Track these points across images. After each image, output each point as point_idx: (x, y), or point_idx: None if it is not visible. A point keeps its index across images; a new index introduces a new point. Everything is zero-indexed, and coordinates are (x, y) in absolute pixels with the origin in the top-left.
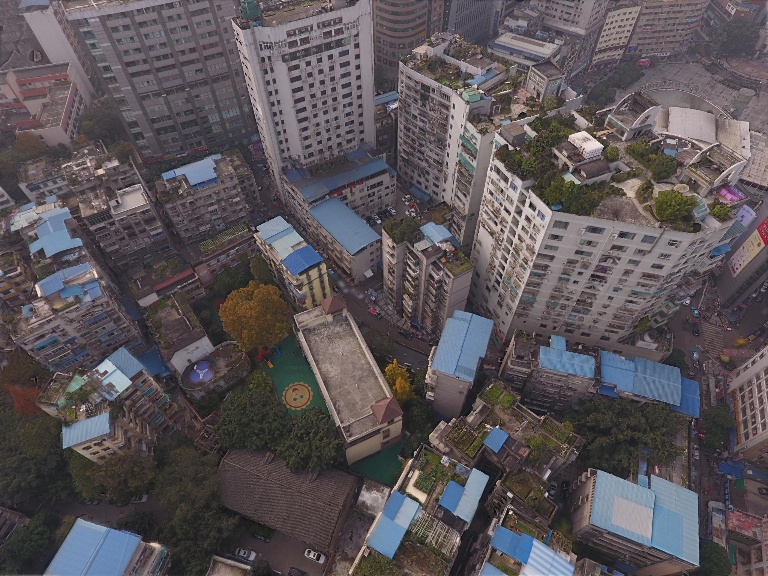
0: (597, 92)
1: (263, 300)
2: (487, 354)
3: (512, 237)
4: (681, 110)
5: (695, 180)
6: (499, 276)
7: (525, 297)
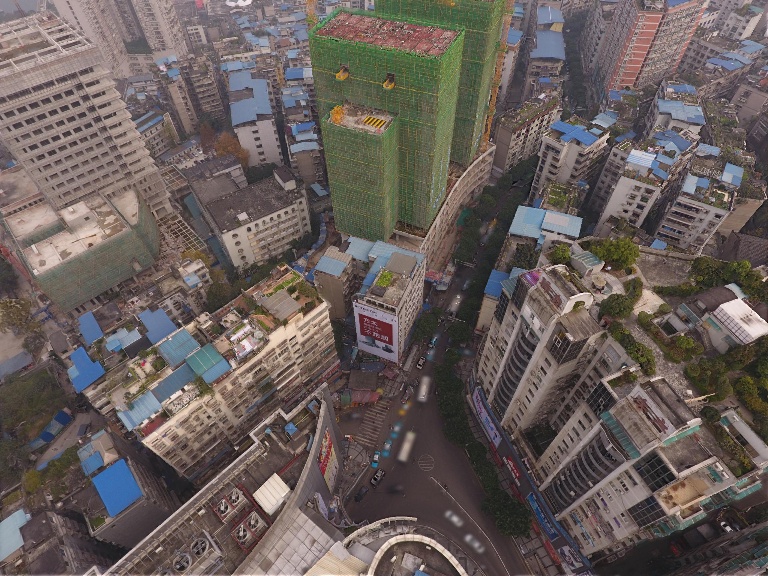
0: None
1: None
2: None
3: None
4: None
5: None
6: None
7: None
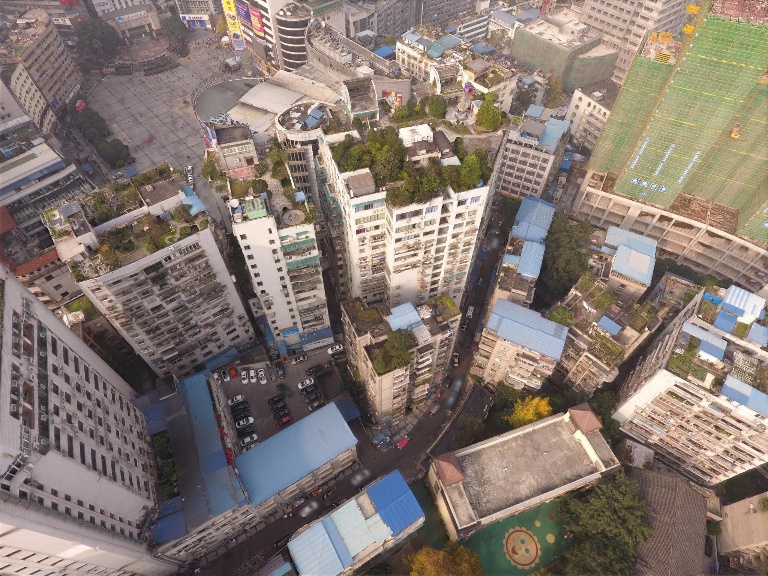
0: (112, 152)
1: (445, 573)
2: (456, 338)
3: (443, 244)
4: (249, 96)
5: (456, 96)
6: (433, 285)
7: (470, 267)
